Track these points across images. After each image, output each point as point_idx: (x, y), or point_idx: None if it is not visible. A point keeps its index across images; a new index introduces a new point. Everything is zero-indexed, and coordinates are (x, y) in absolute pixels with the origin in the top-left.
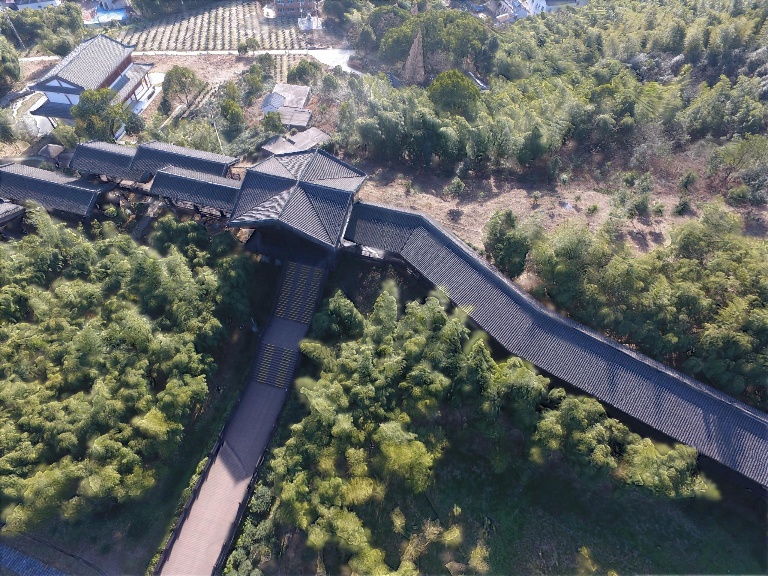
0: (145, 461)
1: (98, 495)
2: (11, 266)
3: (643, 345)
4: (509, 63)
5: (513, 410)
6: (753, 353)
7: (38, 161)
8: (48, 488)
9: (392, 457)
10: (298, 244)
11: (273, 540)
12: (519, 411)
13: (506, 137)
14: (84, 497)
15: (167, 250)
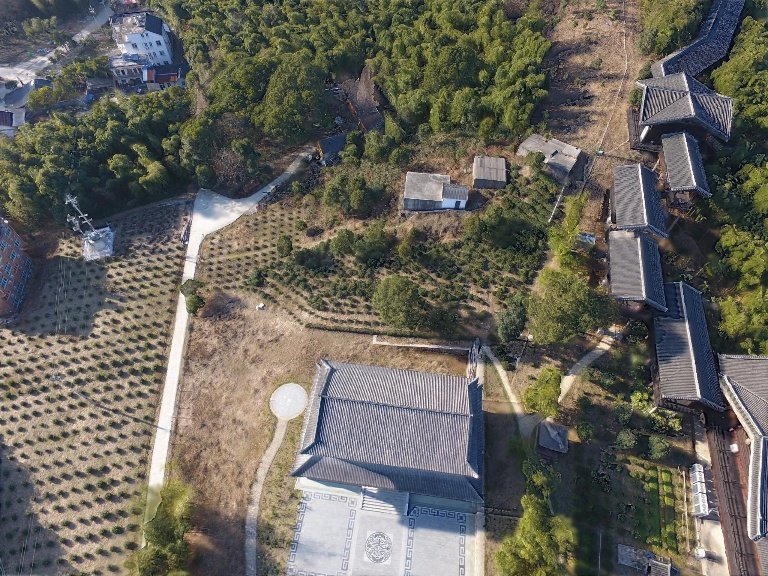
0: None
1: None
2: None
3: None
4: (342, 54)
5: None
6: None
7: None
8: None
9: None
10: None
11: None
12: None
13: None
14: None
15: None
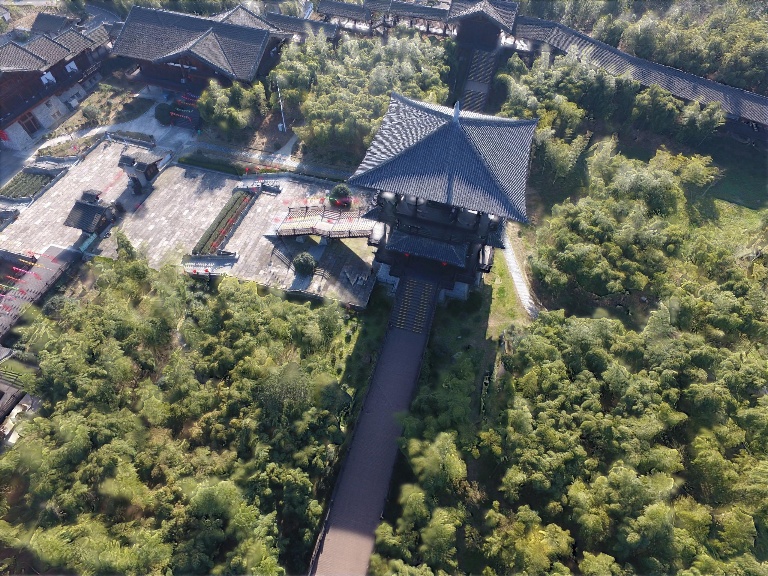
0: None
1: None
2: None
3: (690, 73)
4: None
5: (622, 95)
6: (750, 68)
7: None
8: None
9: (563, 108)
10: (480, 40)
11: None
12: (626, 92)
13: (592, 1)
14: None
15: None
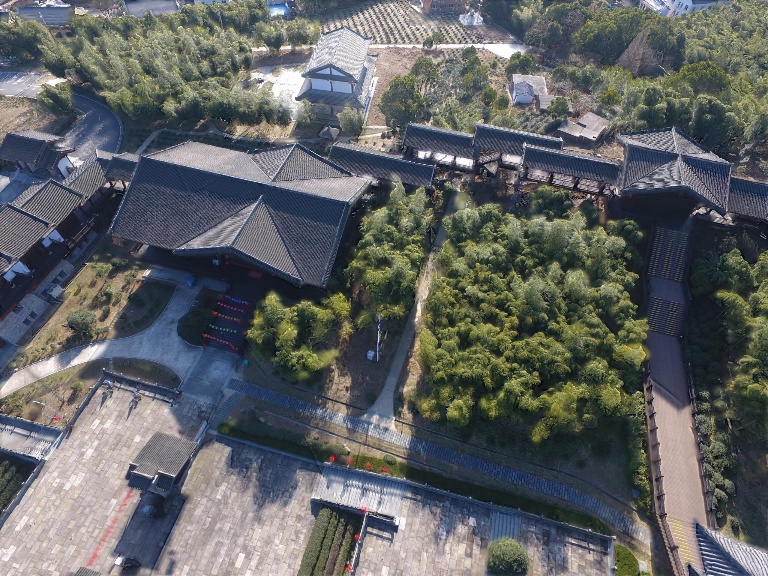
0: (623, 388)
1: (604, 413)
2: (398, 230)
3: None
4: (707, 57)
5: None
6: None
7: (309, 143)
8: (571, 406)
9: None
10: (663, 211)
11: (732, 457)
12: None
13: None
14: (594, 415)
15: (545, 216)
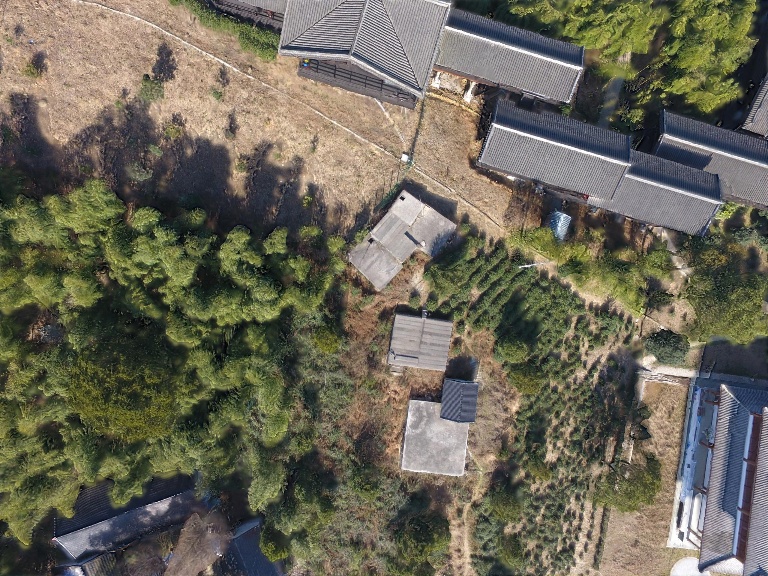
0: None
1: None
2: None
3: None
4: None
5: None
6: None
7: None
8: None
9: None
10: None
11: None
12: None
13: None
14: None
15: None
